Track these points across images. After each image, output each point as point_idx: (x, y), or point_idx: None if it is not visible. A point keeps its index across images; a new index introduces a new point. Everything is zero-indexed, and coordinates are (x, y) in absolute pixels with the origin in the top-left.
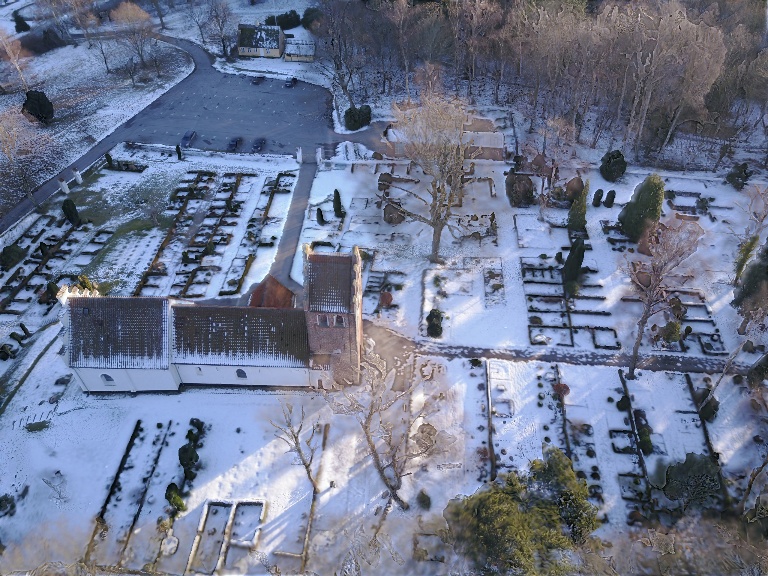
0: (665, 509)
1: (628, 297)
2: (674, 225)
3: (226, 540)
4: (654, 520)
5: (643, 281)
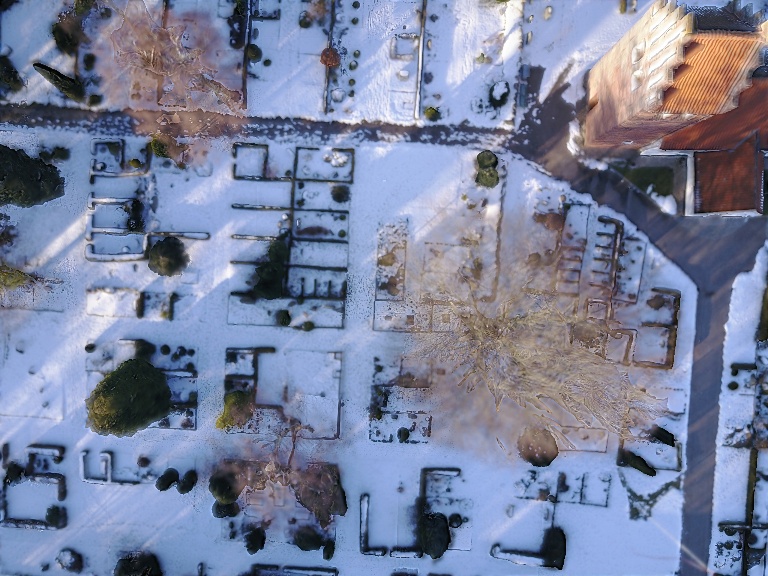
0: None
1: (200, 235)
2: (75, 428)
3: None
4: None
5: (173, 251)
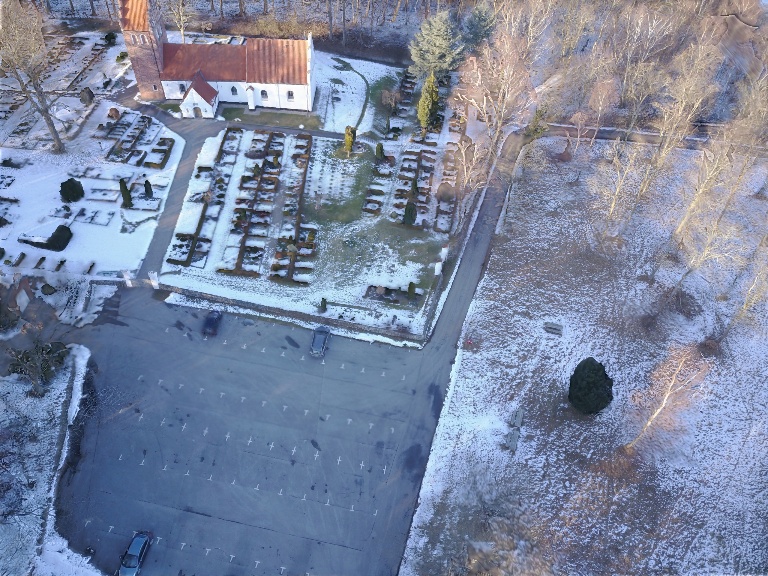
0: None
1: None
2: None
3: (227, 42)
4: None
5: None
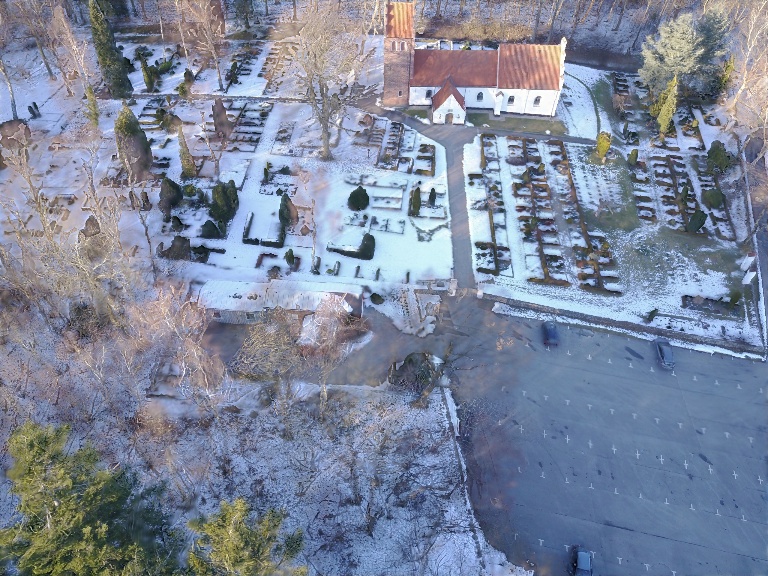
0: (241, 54)
1: None
2: None
3: (439, 46)
4: (248, 53)
5: None
